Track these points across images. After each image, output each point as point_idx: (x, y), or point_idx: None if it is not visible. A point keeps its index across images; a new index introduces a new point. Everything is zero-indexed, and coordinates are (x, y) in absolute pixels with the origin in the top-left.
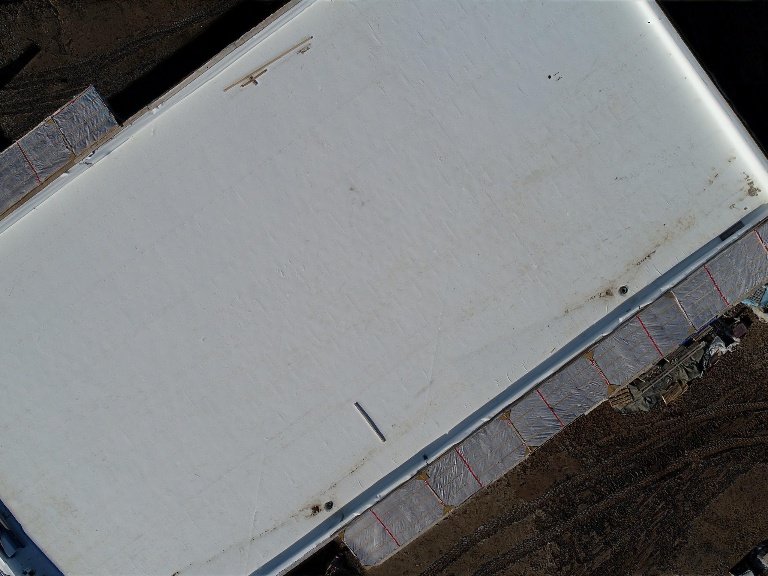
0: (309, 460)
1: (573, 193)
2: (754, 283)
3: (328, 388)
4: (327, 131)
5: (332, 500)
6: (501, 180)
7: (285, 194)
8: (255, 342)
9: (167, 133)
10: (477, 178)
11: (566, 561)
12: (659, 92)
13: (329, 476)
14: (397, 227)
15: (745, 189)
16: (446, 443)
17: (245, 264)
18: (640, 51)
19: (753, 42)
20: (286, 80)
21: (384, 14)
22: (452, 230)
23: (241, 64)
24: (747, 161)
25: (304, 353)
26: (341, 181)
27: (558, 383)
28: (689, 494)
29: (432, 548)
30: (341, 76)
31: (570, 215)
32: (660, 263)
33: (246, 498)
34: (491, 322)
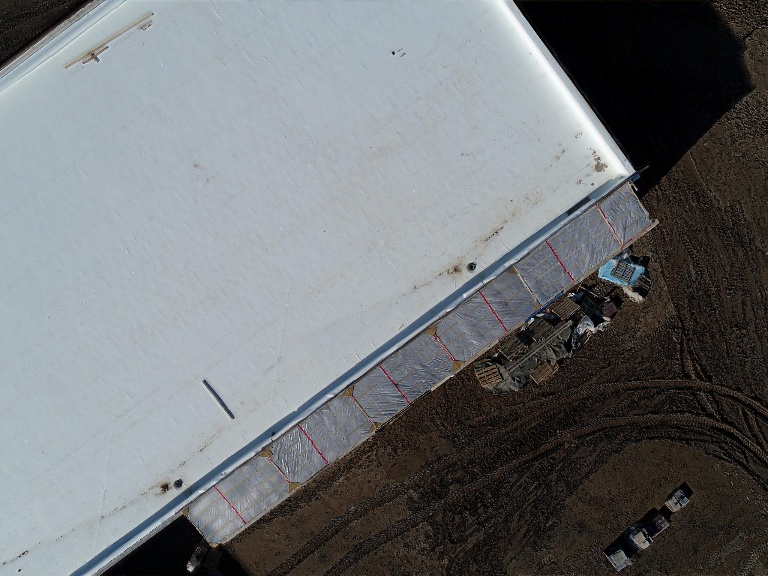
0: (158, 438)
1: (419, 169)
2: (598, 258)
3: (176, 366)
4: (170, 108)
5: (181, 478)
6: (346, 156)
7: (129, 171)
8: (101, 320)
9: (9, 110)
10: (322, 155)
11: (439, 542)
12: (504, 68)
13: (178, 454)
14: (242, 204)
15: (592, 165)
16: (291, 420)
17: (90, 241)
18: (484, 27)
19: (620, 21)
20: (128, 57)
21: None
22: (298, 207)
23: (82, 41)
24: (593, 137)
25: (151, 331)
26: (185, 158)
27: (401, 359)
28: (562, 474)
29: (304, 529)
30: (183, 53)
31: (416, 191)
32: (508, 239)
33: (95, 476)
34: (339, 299)
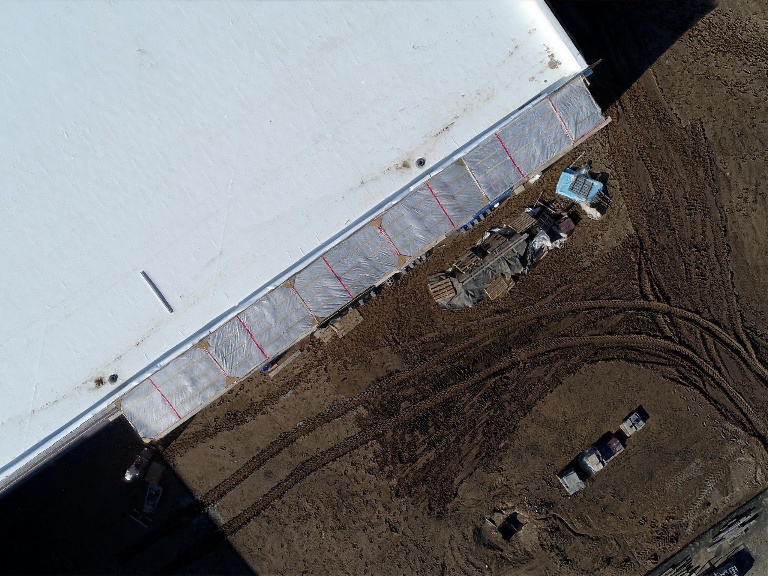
0: (93, 330)
1: (369, 60)
2: (549, 154)
3: (113, 255)
4: None
5: (117, 372)
6: (294, 45)
7: (70, 53)
8: (37, 205)
9: None
10: (270, 42)
11: (388, 461)
12: None
13: (114, 347)
14: (186, 90)
15: (545, 61)
16: (231, 312)
17: (28, 124)
18: None
19: None
20: None
21: None
22: (243, 95)
23: None
24: (546, 32)
25: (89, 218)
26: (129, 41)
27: (345, 251)
28: (516, 394)
29: (249, 444)
30: None
31: (366, 83)
32: (458, 135)
33: (26, 368)
34: (284, 191)
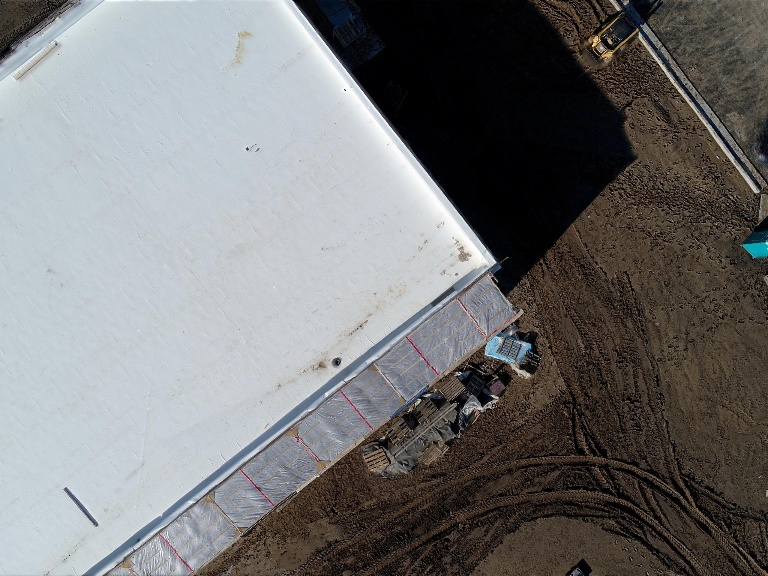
0: (20, 549)
1: (278, 265)
2: (463, 351)
3: (36, 474)
4: (20, 212)
5: None
6: (203, 255)
7: None
8: None
9: None
10: (178, 254)
11: None
12: (361, 160)
13: (42, 564)
14: (98, 307)
15: (455, 254)
16: None
17: None
18: (339, 119)
19: (496, 96)
20: None
21: (72, 92)
22: (155, 308)
23: None
24: (454, 226)
25: (8, 439)
26: (37, 263)
27: (263, 462)
28: (457, 556)
29: None
30: (31, 156)
31: (277, 288)
32: (373, 333)
33: None
34: (201, 400)
